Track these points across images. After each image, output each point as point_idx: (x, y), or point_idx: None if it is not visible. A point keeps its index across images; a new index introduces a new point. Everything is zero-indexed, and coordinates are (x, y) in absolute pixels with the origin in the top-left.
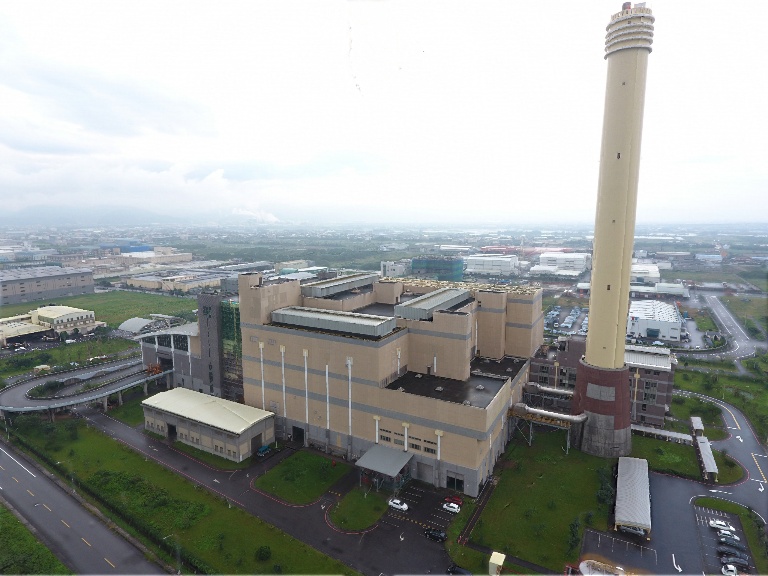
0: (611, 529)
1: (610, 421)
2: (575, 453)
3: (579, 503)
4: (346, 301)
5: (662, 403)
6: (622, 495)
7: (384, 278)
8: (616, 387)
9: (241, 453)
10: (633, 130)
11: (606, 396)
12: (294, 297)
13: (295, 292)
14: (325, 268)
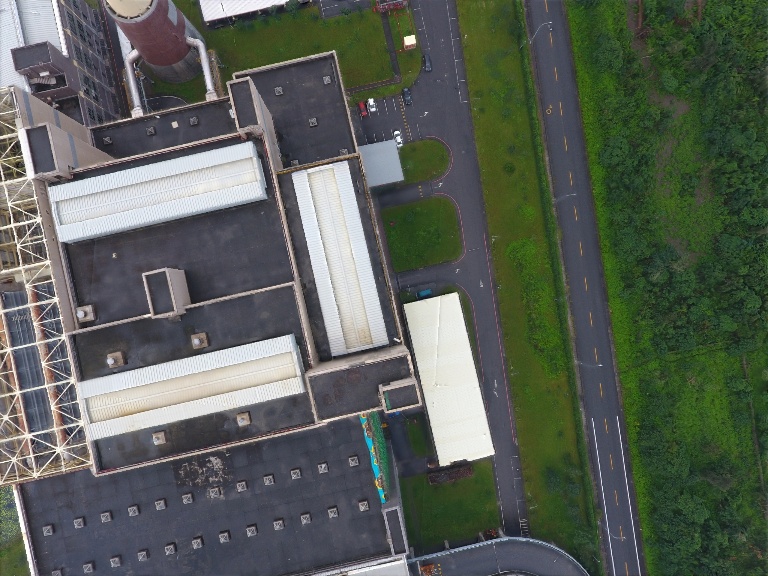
0: (312, 4)
1: None
2: None
3: (295, 32)
4: (281, 285)
5: None
6: (272, 1)
7: (5, 441)
8: None
9: None
10: None
11: (172, 3)
12: None
13: None
14: None
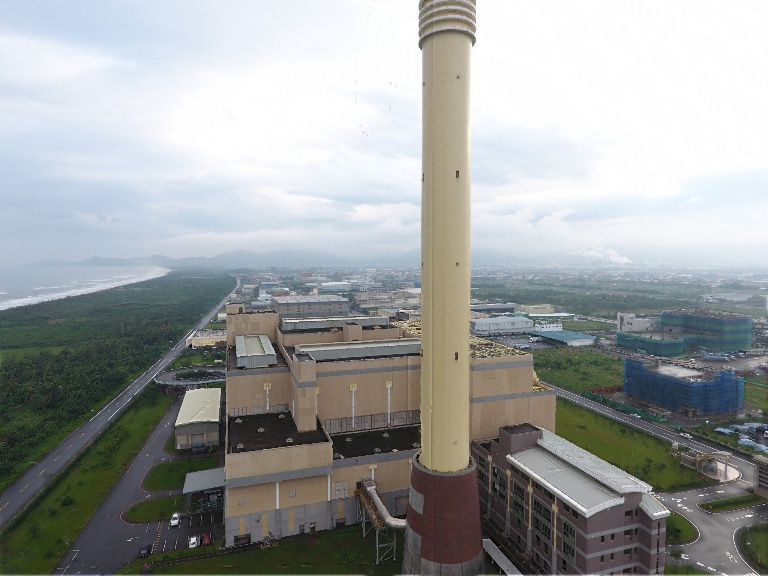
0: None
1: (417, 541)
2: (391, 568)
3: None
4: (289, 336)
5: (582, 569)
6: None
7: None
8: (425, 496)
9: (179, 443)
10: (434, 142)
11: (415, 504)
12: (270, 327)
13: (271, 323)
14: (570, 315)
